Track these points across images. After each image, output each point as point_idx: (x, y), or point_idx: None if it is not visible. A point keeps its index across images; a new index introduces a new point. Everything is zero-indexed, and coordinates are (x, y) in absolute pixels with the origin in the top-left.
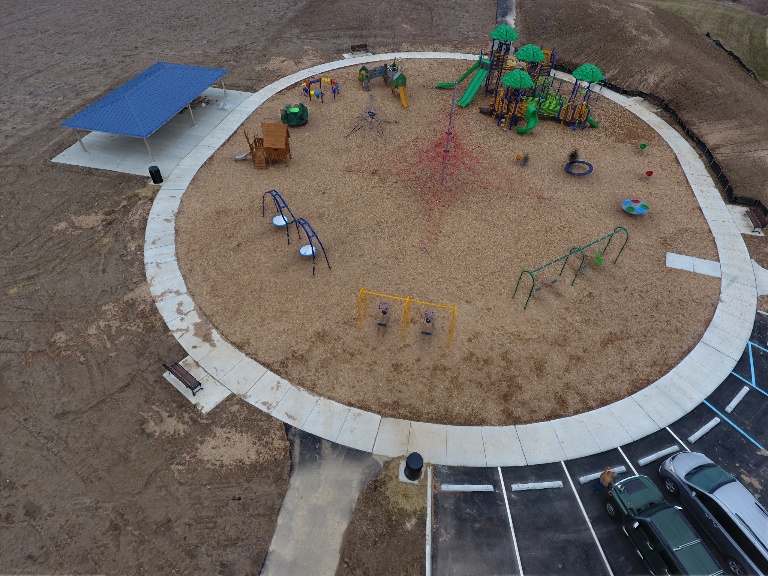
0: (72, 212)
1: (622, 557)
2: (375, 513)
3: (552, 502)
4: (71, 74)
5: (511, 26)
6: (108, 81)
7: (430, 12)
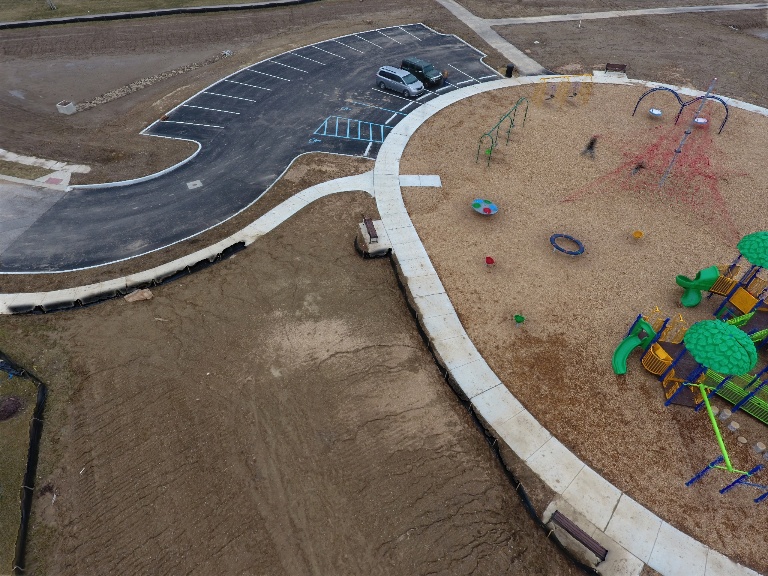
0: None
1: None
2: None
3: (458, 81)
4: None
5: None
6: None
7: None
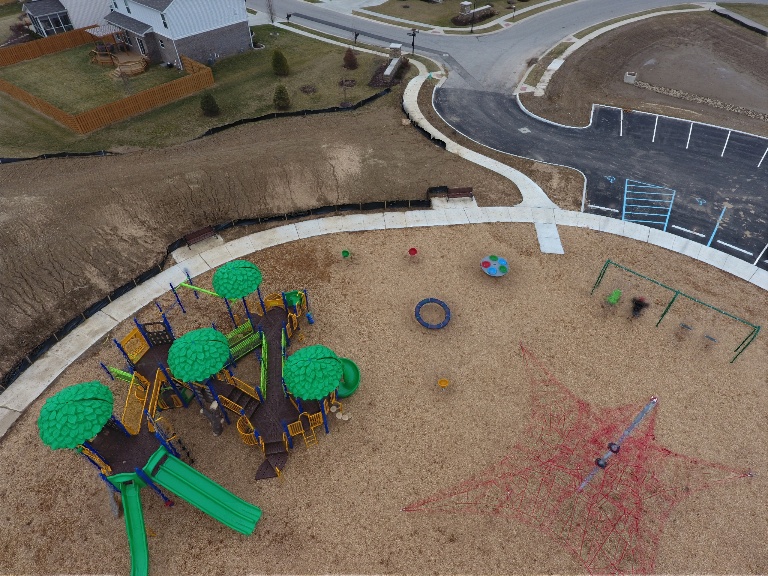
0: None
1: None
2: None
3: None
4: None
5: None
6: None
7: None
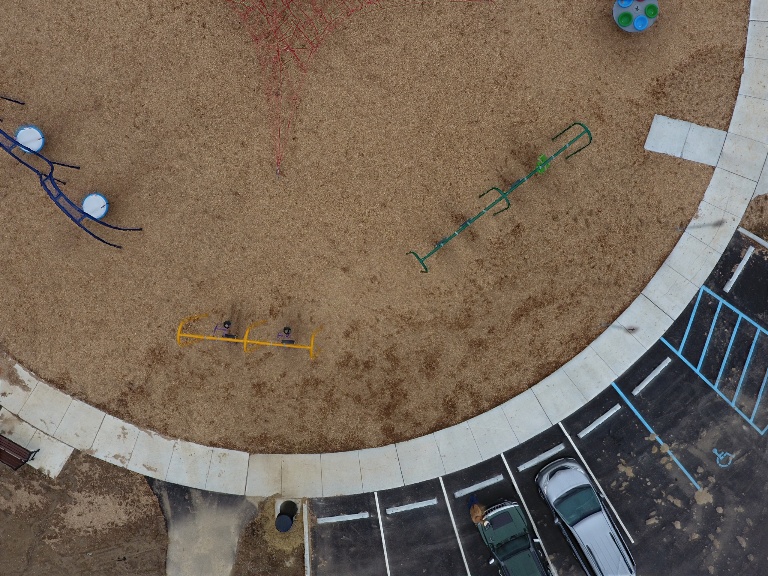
0: None
1: (480, 556)
2: (256, 554)
3: (424, 518)
4: None
5: None
6: None
7: None
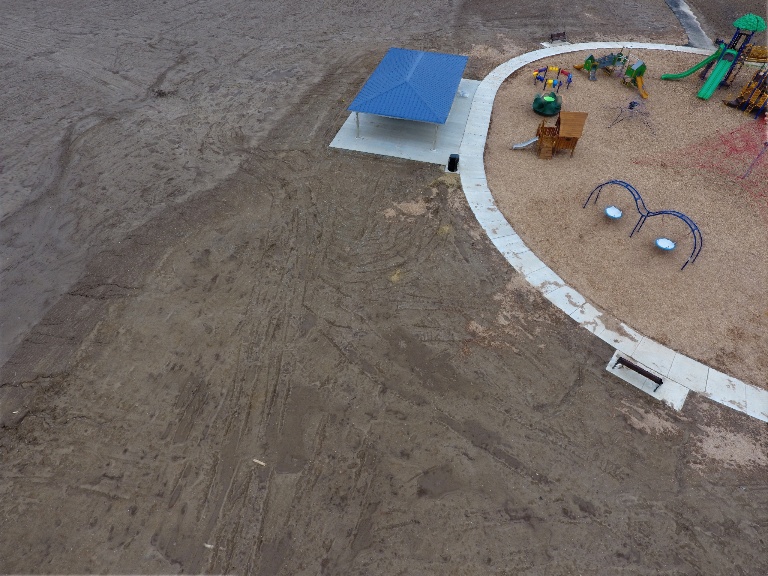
0: (391, 199)
1: None
2: None
3: None
4: (279, 59)
5: (692, 17)
6: (320, 66)
7: (601, 1)
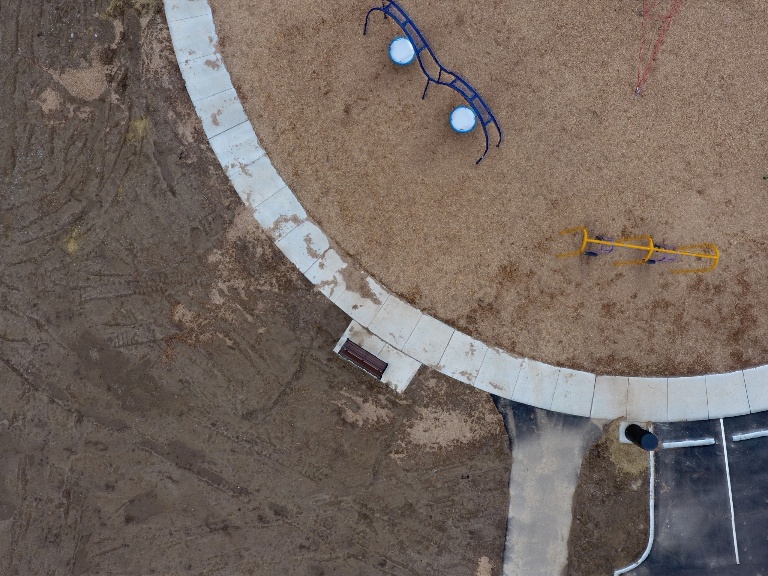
0: (46, 63)
1: None
2: (601, 477)
3: None
4: None
5: None
6: None
7: None
